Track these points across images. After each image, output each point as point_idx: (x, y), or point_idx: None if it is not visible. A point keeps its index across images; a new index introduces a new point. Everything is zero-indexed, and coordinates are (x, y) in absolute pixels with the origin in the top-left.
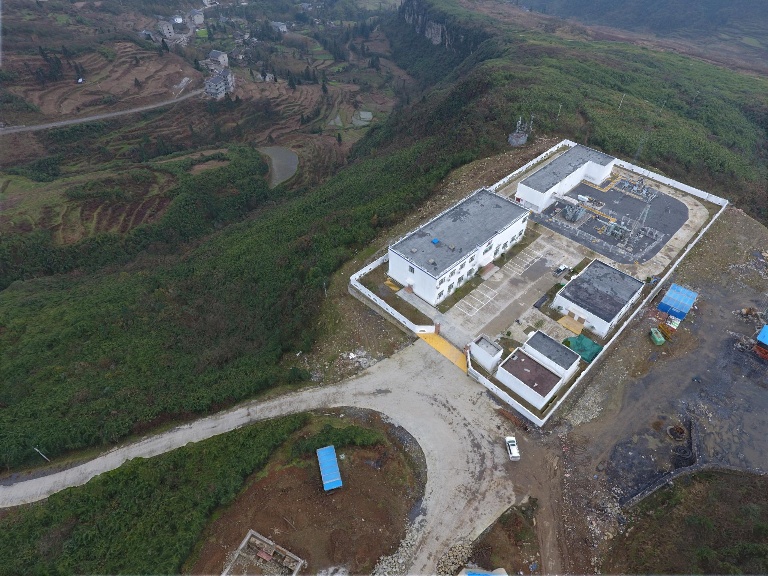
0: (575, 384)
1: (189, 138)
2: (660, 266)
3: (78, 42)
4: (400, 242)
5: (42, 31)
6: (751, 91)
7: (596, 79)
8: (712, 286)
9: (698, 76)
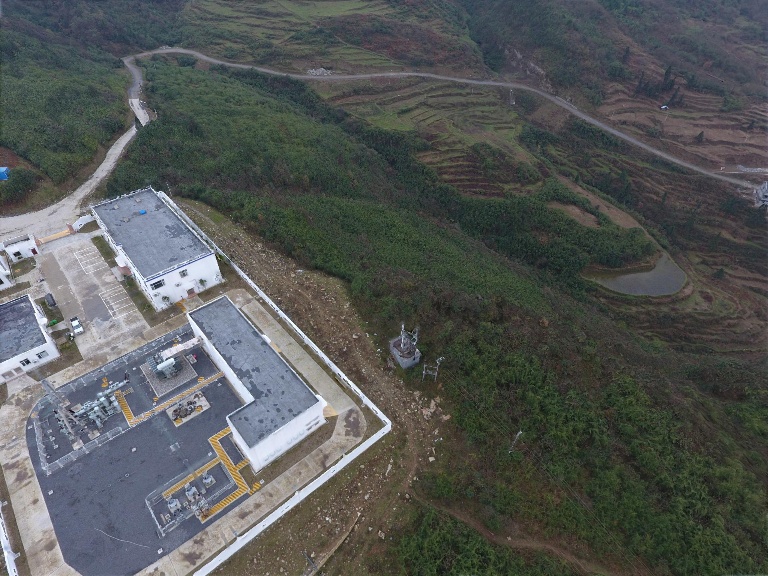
0: None
1: None
2: (4, 442)
3: (720, 81)
4: None
5: (725, 63)
6: None
7: None
8: None
9: None
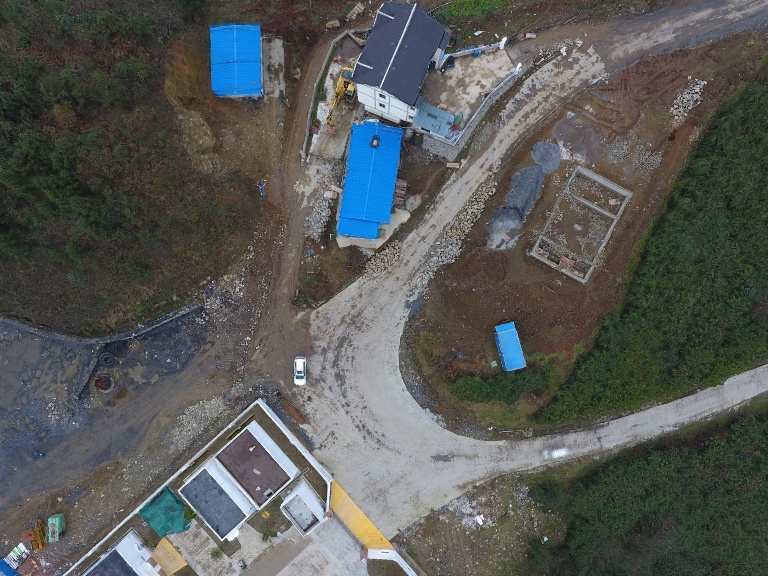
0: (200, 453)
1: None
2: None
3: None
4: None
5: None
6: None
7: None
8: None
9: None
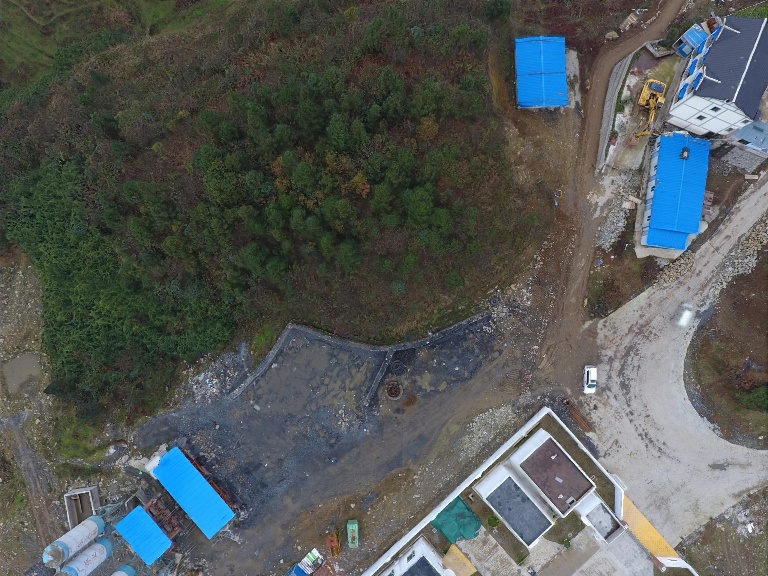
0: (493, 460)
1: None
2: None
3: None
4: None
5: None
6: None
7: None
8: None
9: None
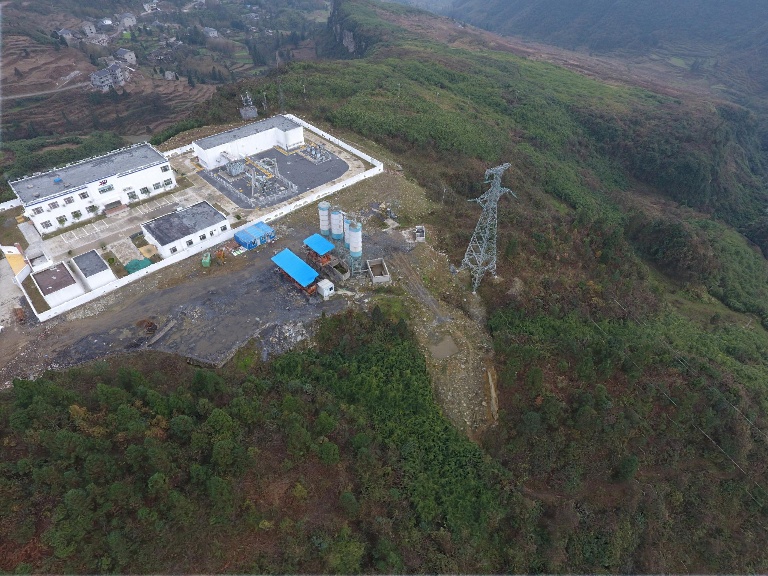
0: (96, 291)
1: (64, 125)
2: None
3: None
4: (26, 180)
5: None
6: (586, 95)
7: (422, 76)
8: (306, 227)
9: (546, 81)
